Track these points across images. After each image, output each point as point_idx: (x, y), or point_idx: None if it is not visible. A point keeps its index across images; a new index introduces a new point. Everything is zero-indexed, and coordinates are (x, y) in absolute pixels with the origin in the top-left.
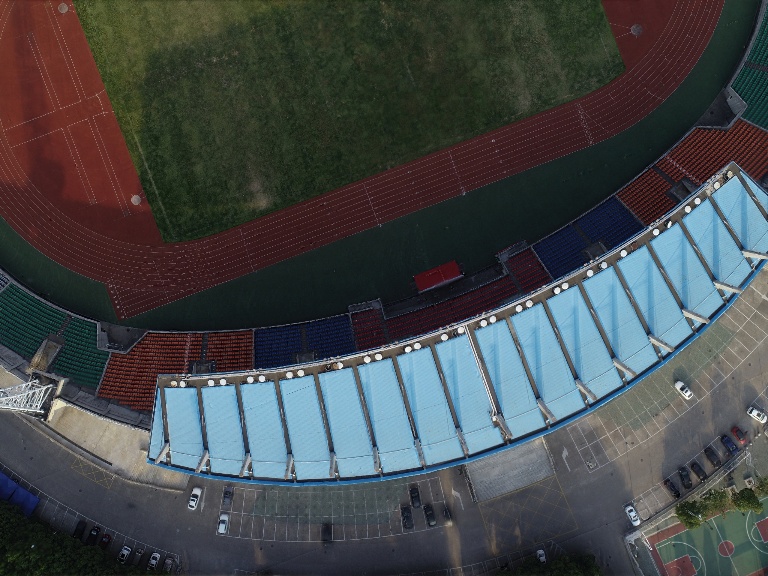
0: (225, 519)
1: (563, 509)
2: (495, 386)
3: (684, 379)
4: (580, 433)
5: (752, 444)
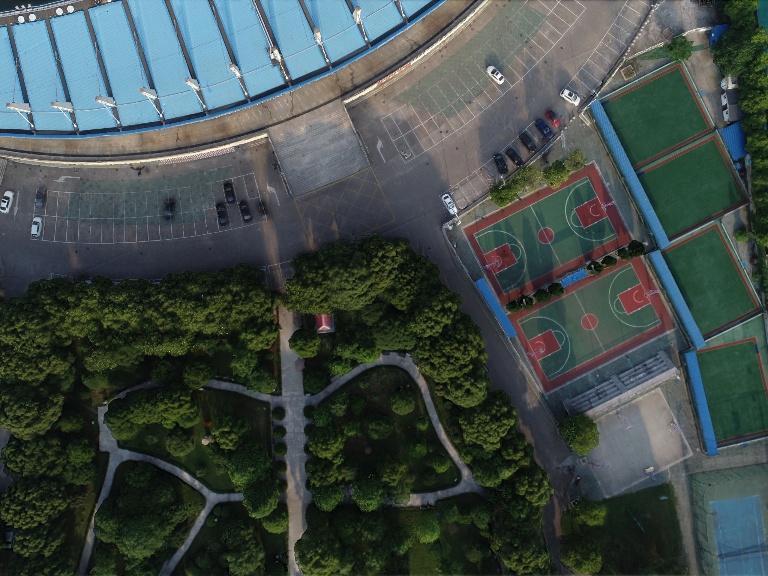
0: (38, 221)
1: (380, 201)
2: (270, 20)
3: (496, 65)
4: (394, 123)
5: (567, 128)
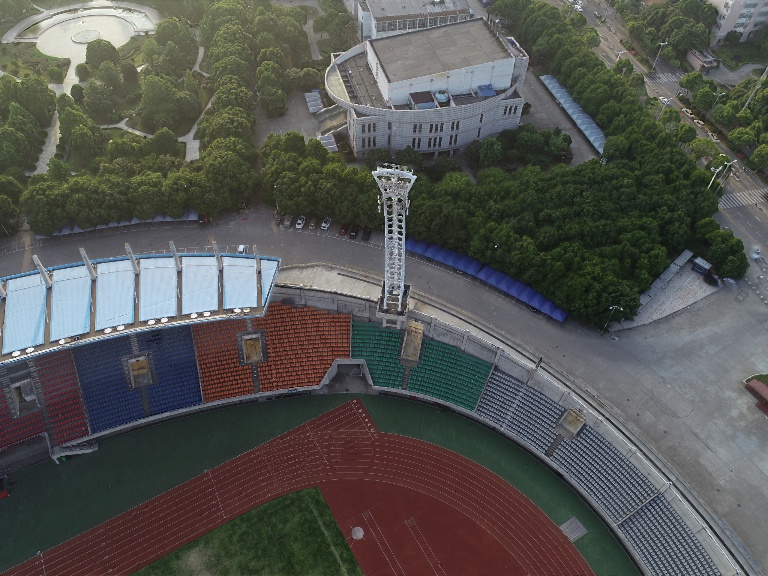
0: None
1: None
2: None
3: None
4: None
5: None
